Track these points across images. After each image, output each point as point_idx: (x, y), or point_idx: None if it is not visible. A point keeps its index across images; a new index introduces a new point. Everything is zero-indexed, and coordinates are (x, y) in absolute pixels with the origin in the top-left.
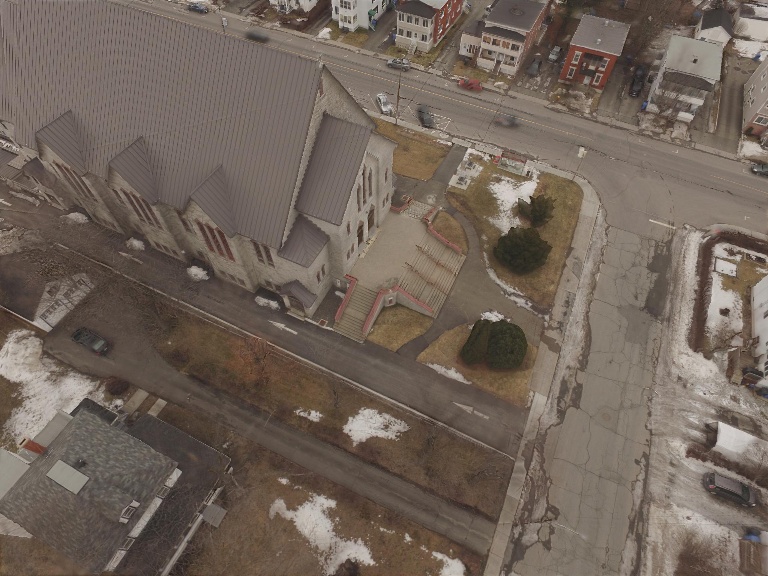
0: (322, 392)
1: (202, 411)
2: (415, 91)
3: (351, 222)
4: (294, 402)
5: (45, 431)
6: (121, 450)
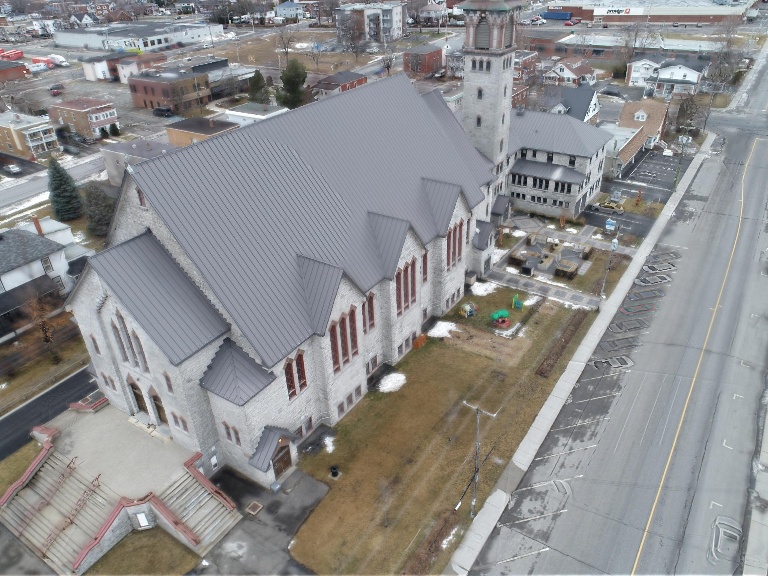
0: (5, 401)
1: (61, 329)
2: (617, 571)
3: (99, 343)
4: (15, 382)
5: (85, 250)
6: (7, 258)
